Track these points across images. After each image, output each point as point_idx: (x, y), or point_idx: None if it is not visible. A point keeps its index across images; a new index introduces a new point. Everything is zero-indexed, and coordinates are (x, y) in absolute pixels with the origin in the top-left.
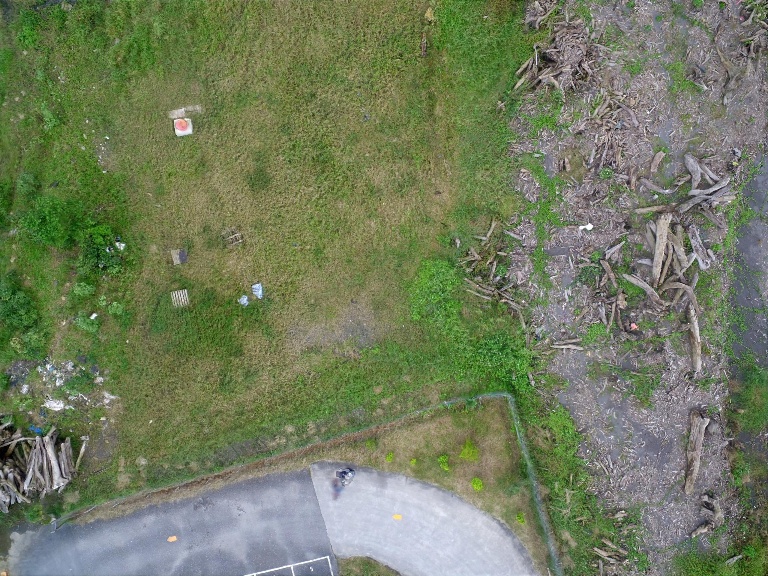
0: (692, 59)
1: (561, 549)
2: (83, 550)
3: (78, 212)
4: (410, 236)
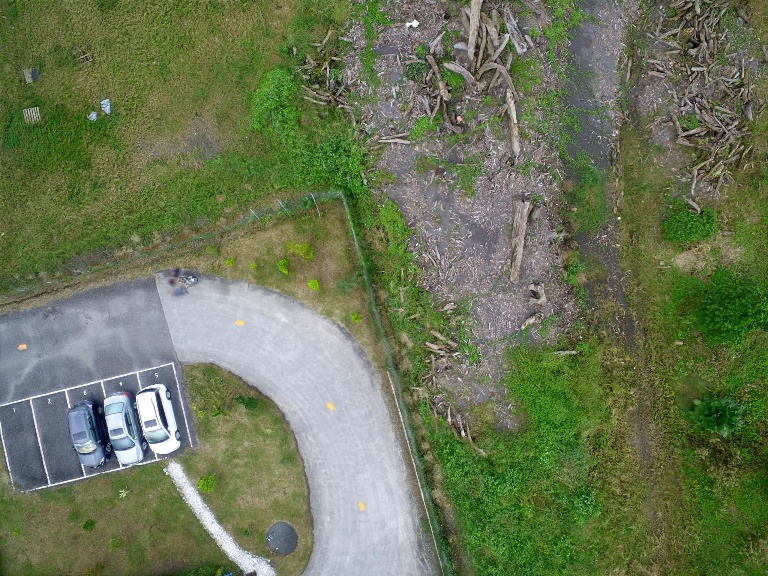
0: None
1: (401, 353)
2: None
3: None
4: (252, 49)
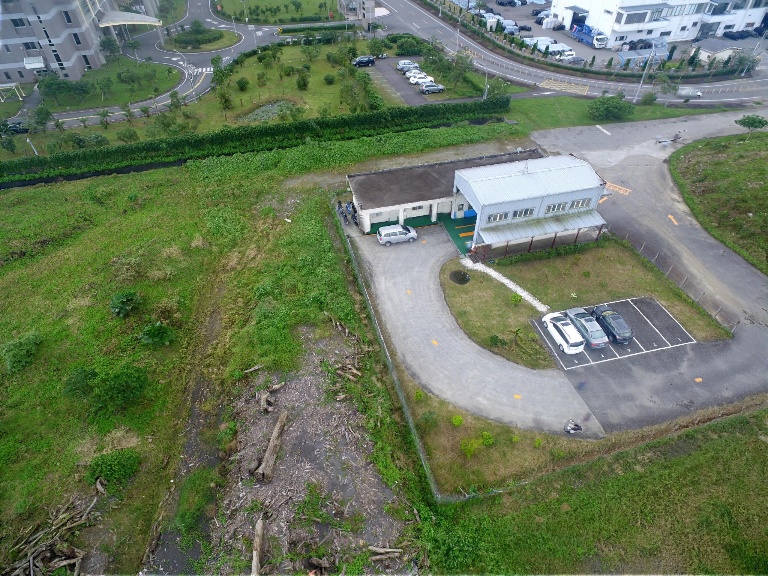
0: None
1: (382, 376)
2: (767, 372)
3: None
4: None
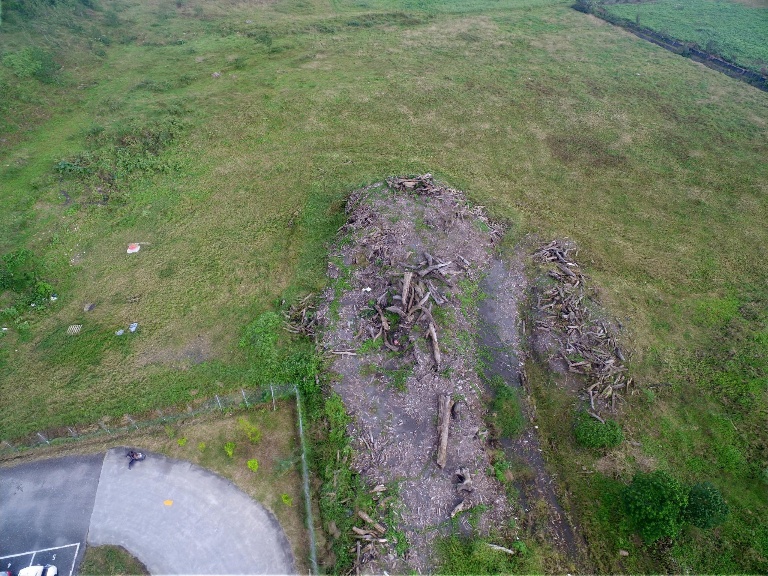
0: (427, 218)
1: (327, 547)
2: None
3: (40, 263)
4: (254, 301)
